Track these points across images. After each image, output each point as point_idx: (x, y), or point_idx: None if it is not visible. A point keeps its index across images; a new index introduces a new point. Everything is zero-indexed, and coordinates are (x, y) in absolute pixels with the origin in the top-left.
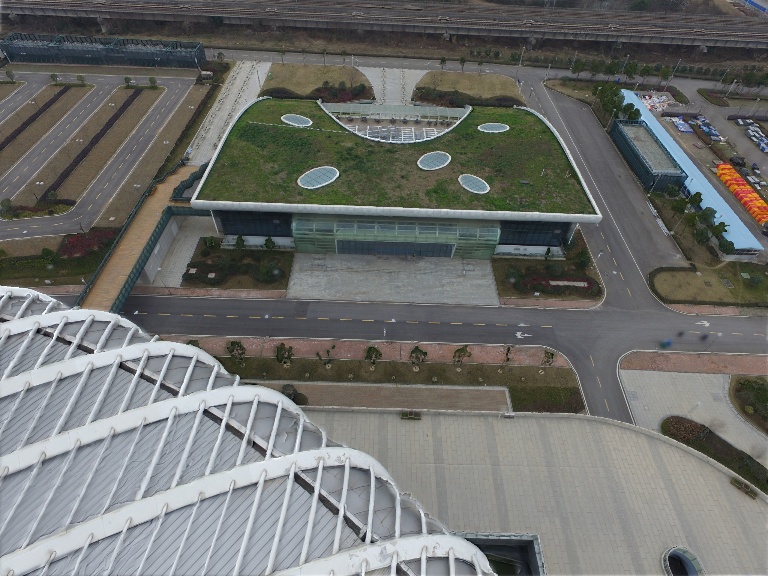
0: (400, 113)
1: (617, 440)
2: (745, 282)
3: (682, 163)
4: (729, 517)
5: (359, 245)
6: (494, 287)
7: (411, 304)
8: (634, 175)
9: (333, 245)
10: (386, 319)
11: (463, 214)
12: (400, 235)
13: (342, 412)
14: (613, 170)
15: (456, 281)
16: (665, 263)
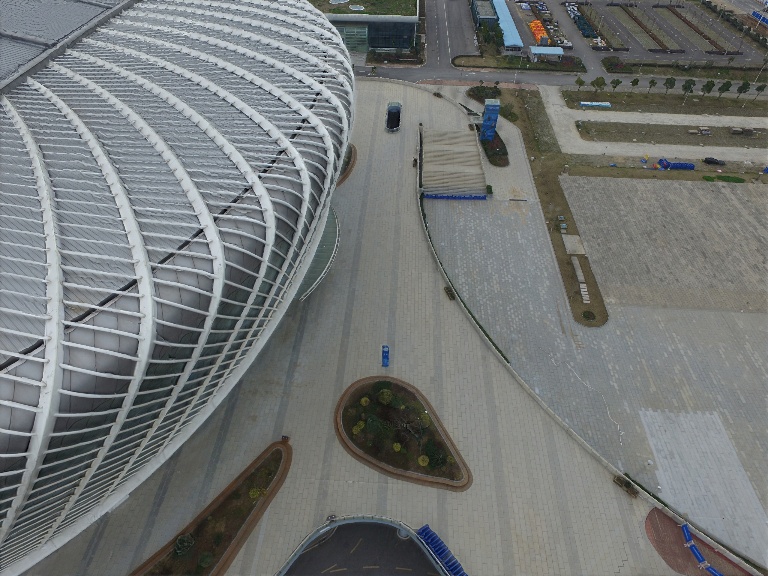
0: None
1: (390, 85)
2: (508, 61)
3: (503, 16)
4: None
5: None
6: (364, 60)
7: None
8: (474, 24)
9: None
10: None
11: (345, 16)
12: None
13: None
14: (463, 23)
15: None
16: None
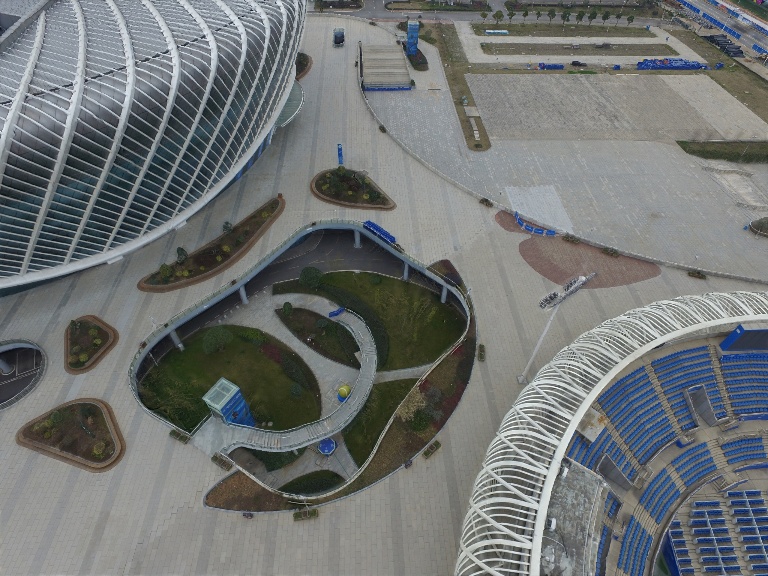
0: None
1: None
2: None
3: None
4: None
5: None
6: (313, 7)
7: None
8: None
9: None
10: None
11: None
12: None
13: None
14: None
15: None
16: None
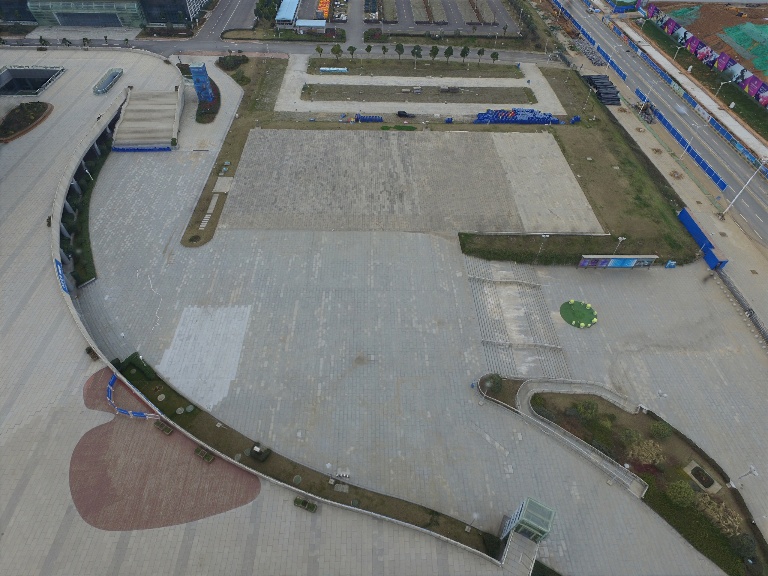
0: None
1: None
2: None
3: None
4: (152, 67)
5: (70, 19)
6: (136, 35)
7: None
8: None
9: (55, 18)
10: None
11: None
12: (85, 8)
13: (12, 49)
14: (256, 0)
15: (118, 33)
16: None
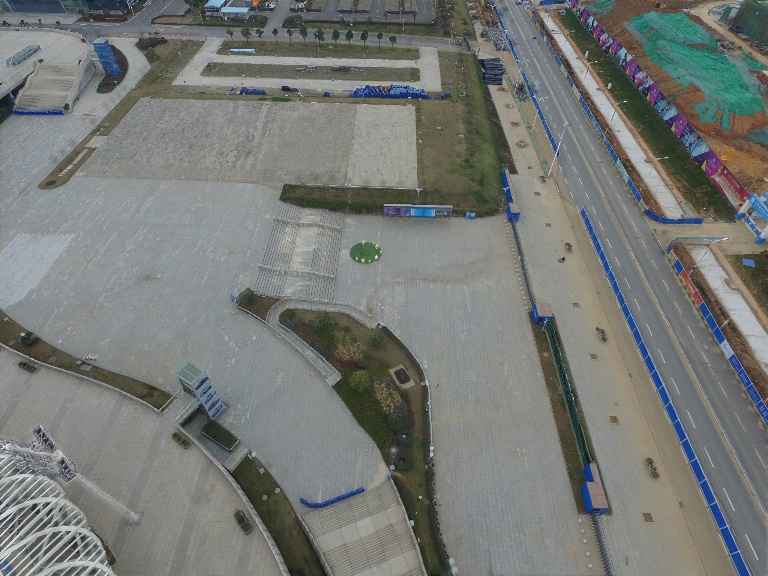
0: None
1: (52, 34)
2: None
3: None
4: None
5: (20, 5)
6: None
7: None
8: None
9: (6, 5)
10: None
11: None
12: None
13: None
14: None
15: None
16: None
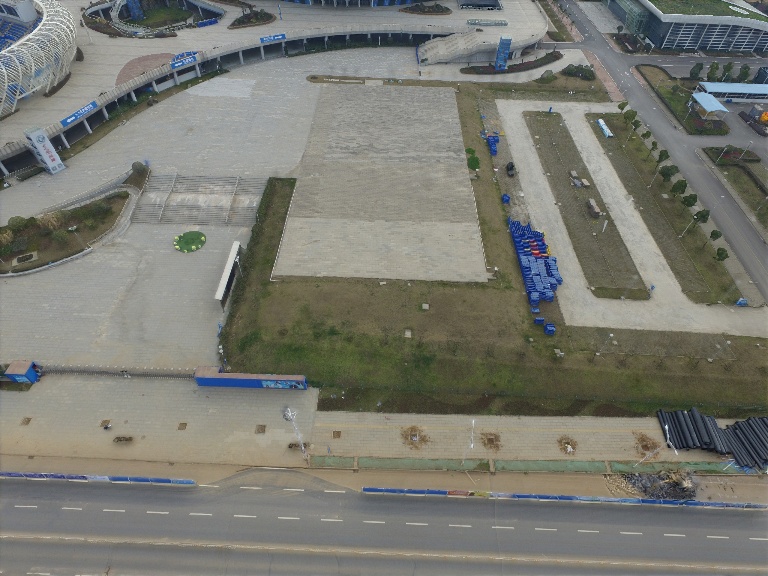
0: (736, 2)
1: None
2: None
3: None
4: None
5: (613, 5)
6: None
7: (589, 19)
8: None
9: None
10: (577, 15)
11: None
12: None
13: None
14: None
15: None
16: (670, 72)
